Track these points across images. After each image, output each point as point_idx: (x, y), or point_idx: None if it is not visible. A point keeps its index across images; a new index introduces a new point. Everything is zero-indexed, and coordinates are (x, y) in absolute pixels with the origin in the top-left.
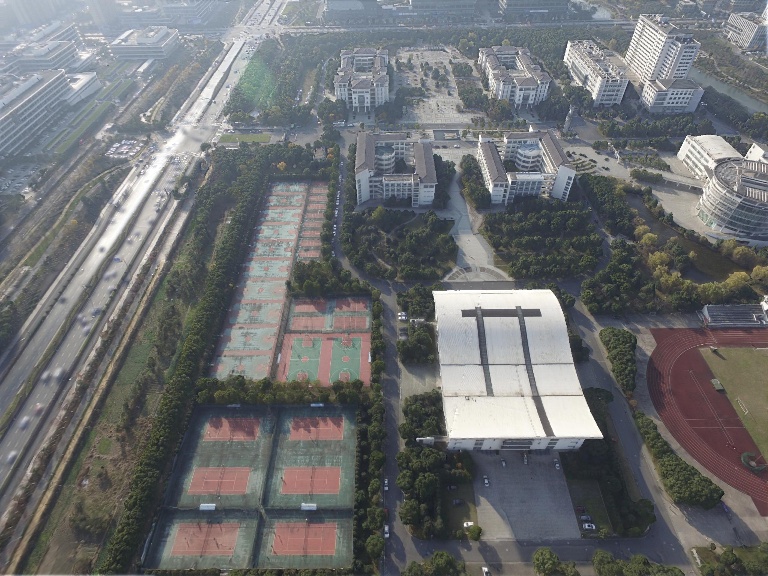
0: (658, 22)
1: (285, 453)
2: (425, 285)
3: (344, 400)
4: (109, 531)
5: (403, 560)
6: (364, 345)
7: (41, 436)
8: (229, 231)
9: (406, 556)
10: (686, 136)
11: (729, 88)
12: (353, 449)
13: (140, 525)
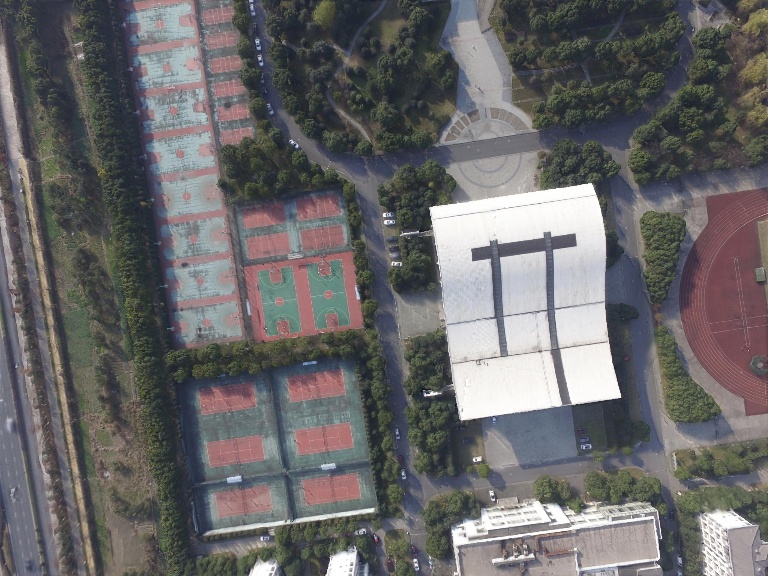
0: None
1: (290, 416)
2: (414, 156)
3: (339, 356)
4: (155, 511)
5: (421, 494)
6: (347, 271)
7: (31, 435)
8: (93, 91)
9: (423, 491)
10: None
11: None
12: (359, 403)
13: (181, 511)
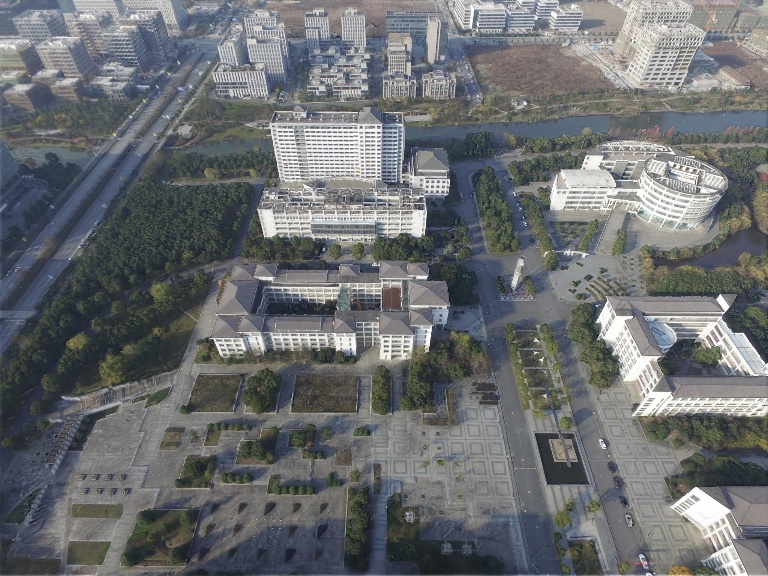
0: (306, 118)
1: None
2: None
3: None
4: None
5: None
6: None
7: None
8: None
9: None
10: (556, 190)
11: None
12: None
13: None
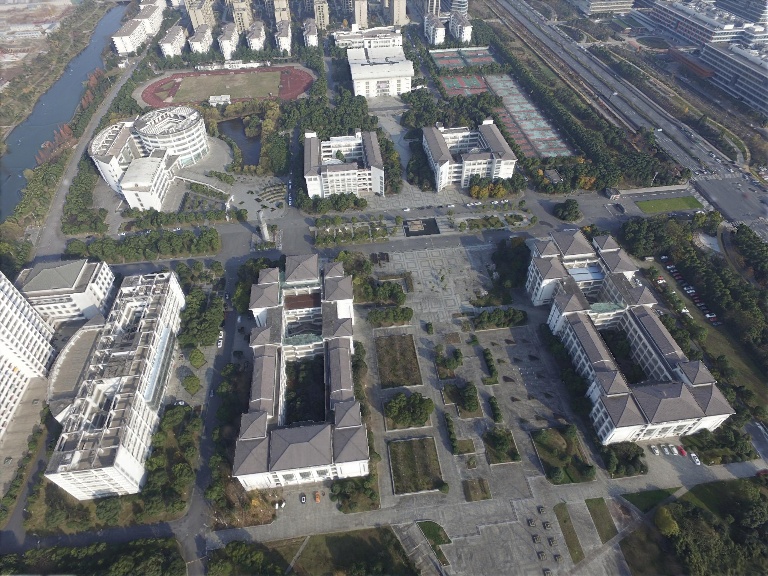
0: None
1: None
2: None
3: None
4: None
5: None
6: None
7: None
8: None
9: None
10: None
11: None
12: None
13: None
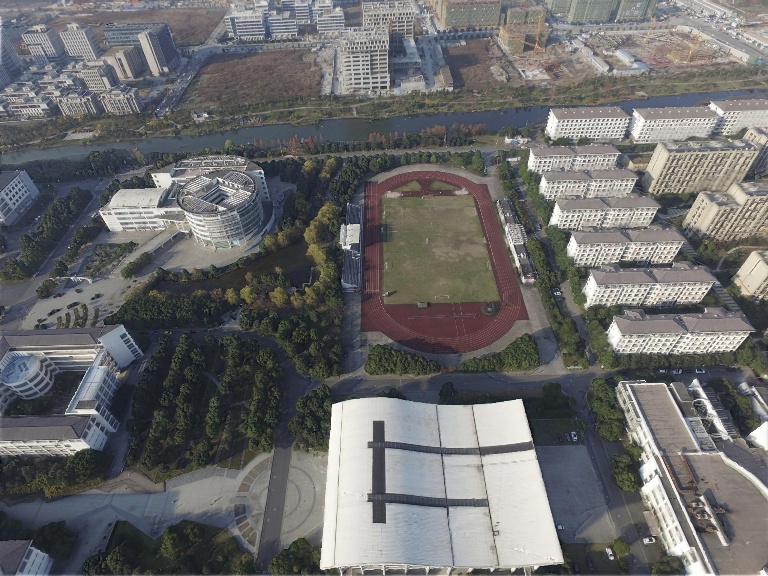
0: None
1: None
2: None
3: None
4: None
5: None
6: None
7: None
8: None
9: None
10: None
11: (10, 156)
12: None
13: None
